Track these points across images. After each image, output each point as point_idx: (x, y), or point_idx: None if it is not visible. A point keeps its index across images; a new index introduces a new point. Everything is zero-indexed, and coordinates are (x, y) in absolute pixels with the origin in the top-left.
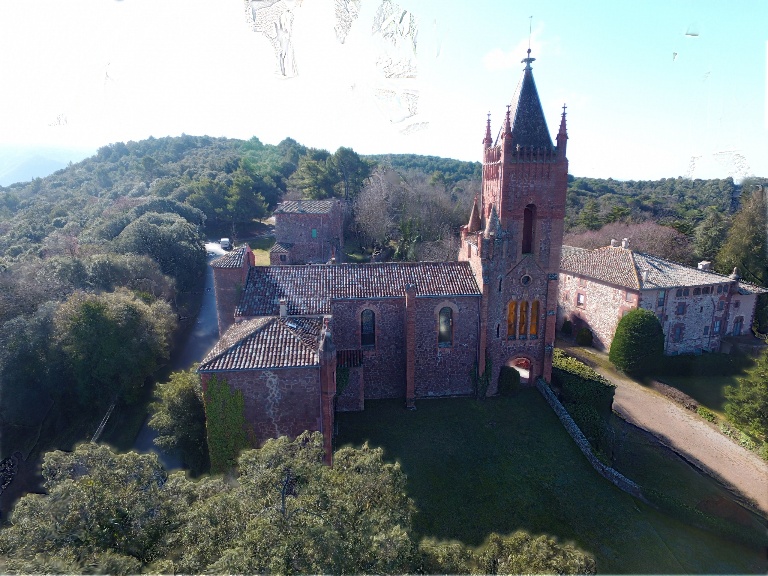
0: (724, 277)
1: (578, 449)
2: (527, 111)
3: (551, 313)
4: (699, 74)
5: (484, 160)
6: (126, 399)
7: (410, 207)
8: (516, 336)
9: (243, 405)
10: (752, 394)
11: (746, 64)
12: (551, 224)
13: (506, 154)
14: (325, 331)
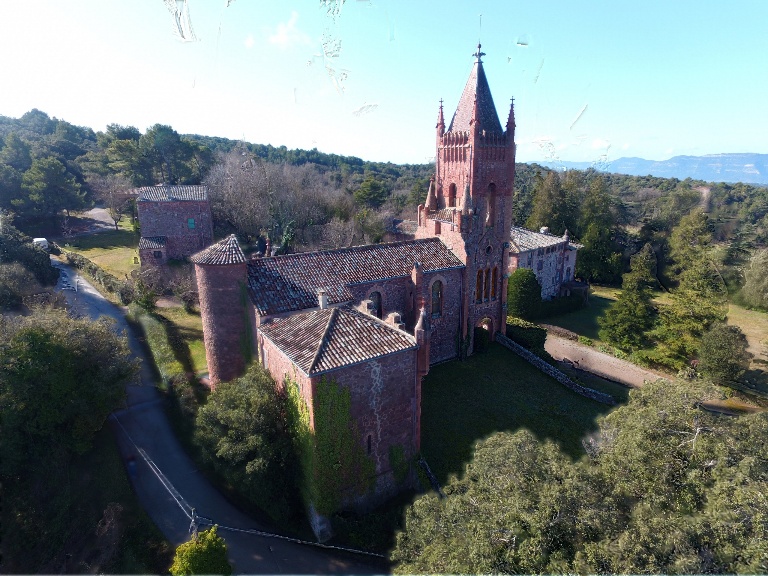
0: (560, 238)
1: (556, 381)
2: (483, 100)
3: (506, 276)
4: (530, 77)
5: (439, 143)
6: (79, 449)
7: (277, 191)
8: (482, 300)
9: (350, 402)
10: (621, 319)
11: (552, 72)
12: (505, 200)
13: (476, 138)
14: (423, 311)
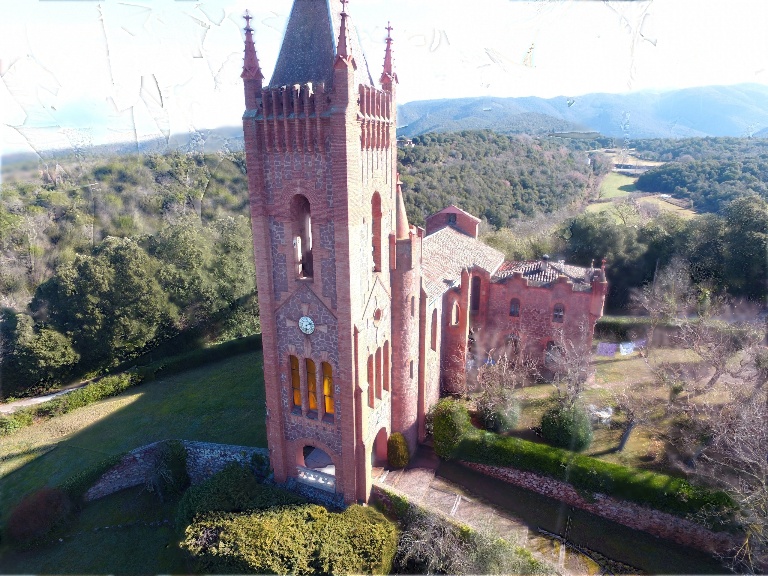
0: None
1: None
2: None
3: None
4: None
5: None
6: None
7: None
8: None
9: None
10: None
11: None
12: None
13: None
14: None
